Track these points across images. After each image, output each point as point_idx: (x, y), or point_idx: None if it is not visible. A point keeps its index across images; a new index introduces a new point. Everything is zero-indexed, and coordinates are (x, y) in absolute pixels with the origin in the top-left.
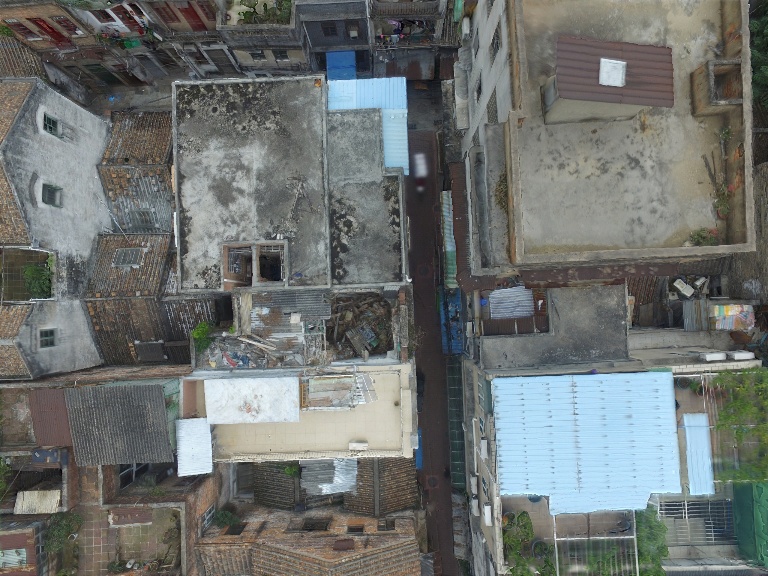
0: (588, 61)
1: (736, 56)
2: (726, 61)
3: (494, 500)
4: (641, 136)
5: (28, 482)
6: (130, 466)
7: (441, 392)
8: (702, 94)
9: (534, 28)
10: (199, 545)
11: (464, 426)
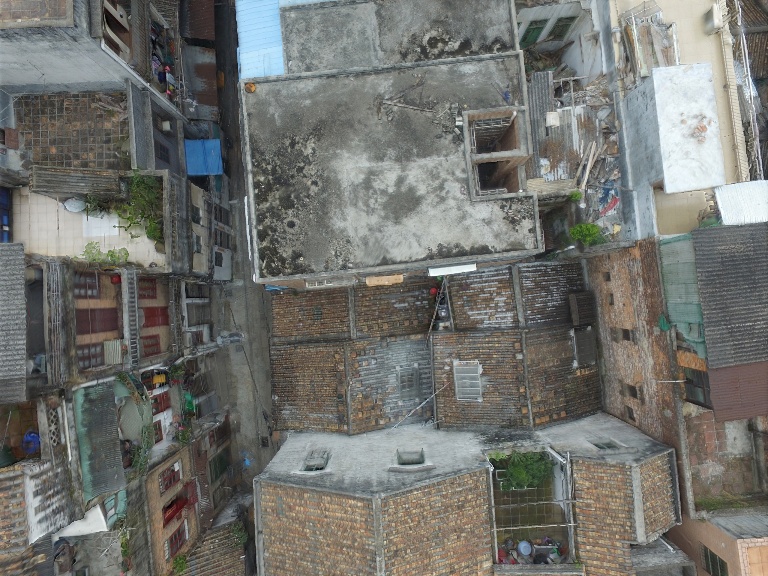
0: None
1: None
2: None
3: None
4: None
5: None
6: None
7: None
8: None
9: None
10: None
11: None
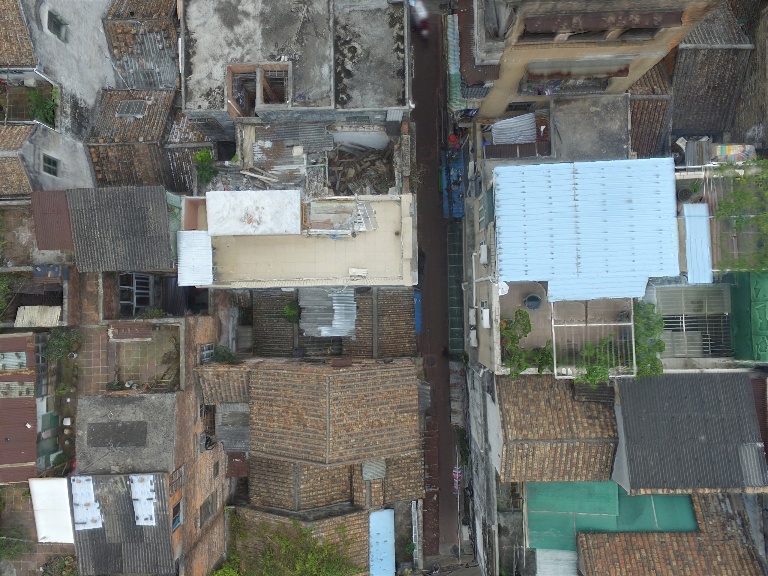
0: None
1: None
2: None
3: (493, 302)
4: None
5: (29, 305)
6: (130, 300)
7: (441, 272)
8: None
9: None
10: (198, 367)
11: (463, 283)
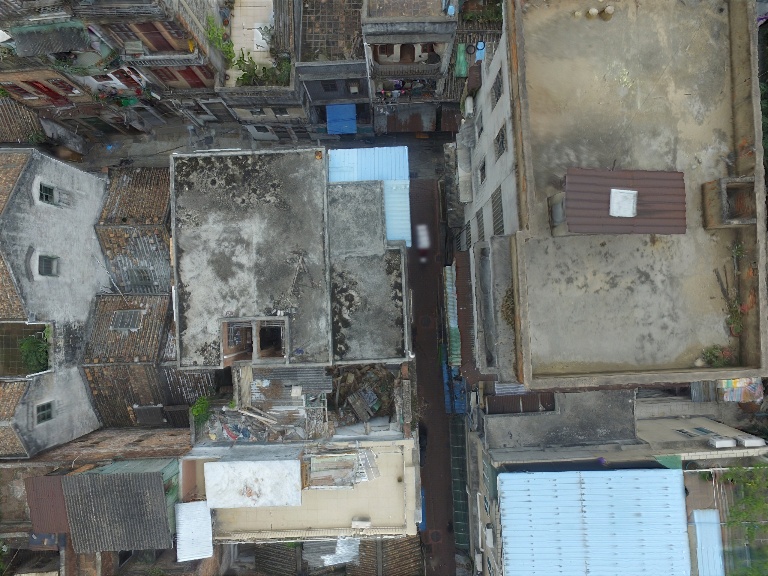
0: (598, 192)
1: (749, 172)
2: (739, 179)
3: None
4: (651, 249)
5: (25, 560)
6: None
7: (444, 445)
8: (714, 210)
9: (541, 137)
10: None
11: (468, 490)
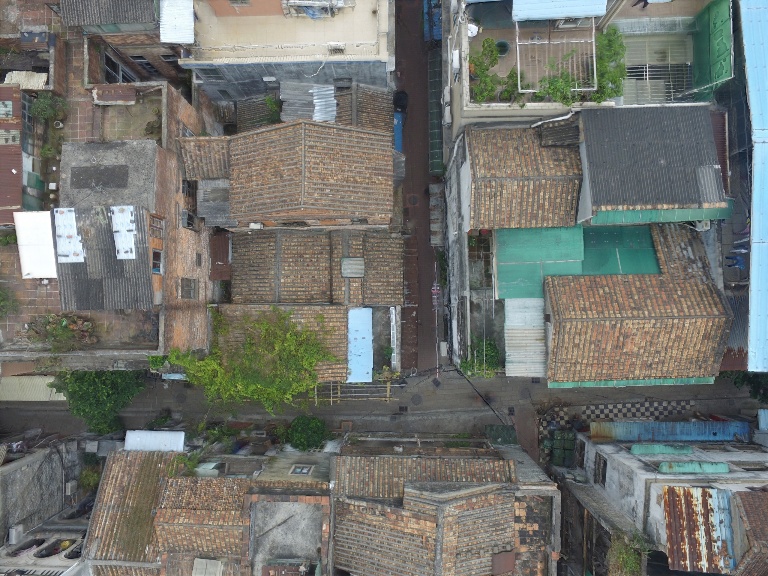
0: None
1: None
2: None
3: (462, 42)
4: None
5: None
6: None
7: (424, 115)
8: None
9: None
10: (180, 137)
11: (442, 94)
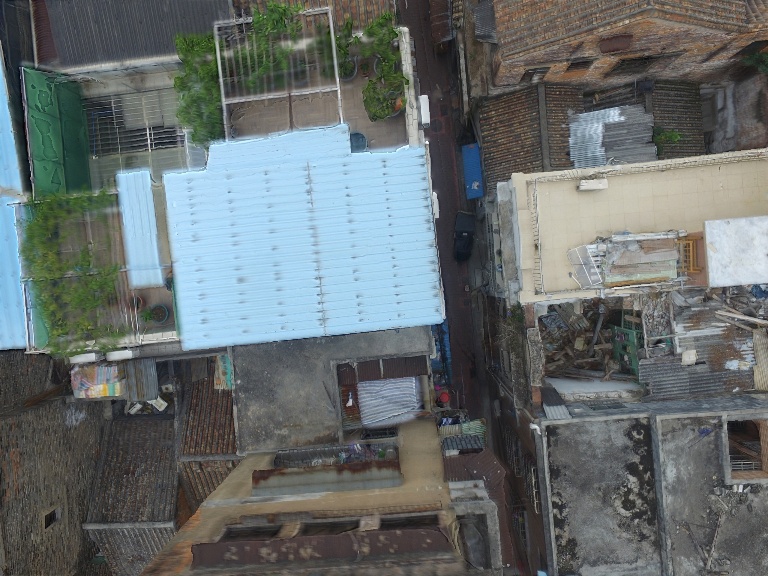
0: None
1: None
2: None
3: None
4: None
5: None
6: None
7: None
8: None
9: None
10: None
11: None
